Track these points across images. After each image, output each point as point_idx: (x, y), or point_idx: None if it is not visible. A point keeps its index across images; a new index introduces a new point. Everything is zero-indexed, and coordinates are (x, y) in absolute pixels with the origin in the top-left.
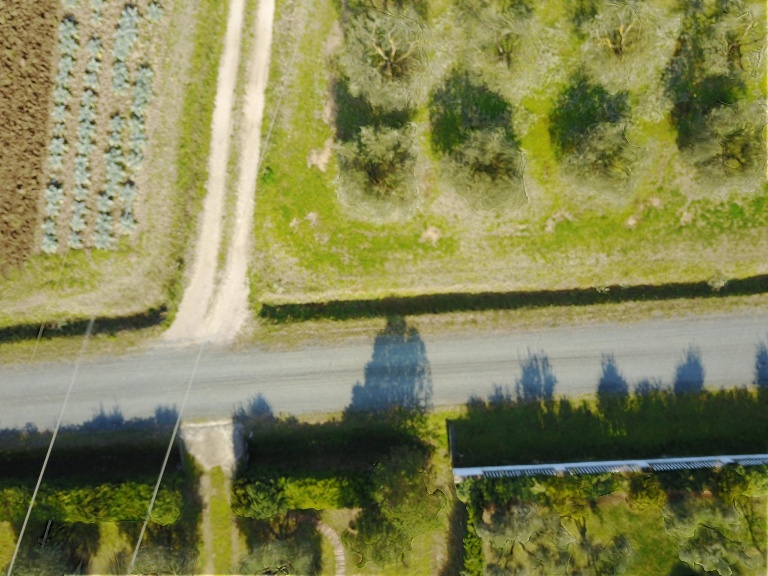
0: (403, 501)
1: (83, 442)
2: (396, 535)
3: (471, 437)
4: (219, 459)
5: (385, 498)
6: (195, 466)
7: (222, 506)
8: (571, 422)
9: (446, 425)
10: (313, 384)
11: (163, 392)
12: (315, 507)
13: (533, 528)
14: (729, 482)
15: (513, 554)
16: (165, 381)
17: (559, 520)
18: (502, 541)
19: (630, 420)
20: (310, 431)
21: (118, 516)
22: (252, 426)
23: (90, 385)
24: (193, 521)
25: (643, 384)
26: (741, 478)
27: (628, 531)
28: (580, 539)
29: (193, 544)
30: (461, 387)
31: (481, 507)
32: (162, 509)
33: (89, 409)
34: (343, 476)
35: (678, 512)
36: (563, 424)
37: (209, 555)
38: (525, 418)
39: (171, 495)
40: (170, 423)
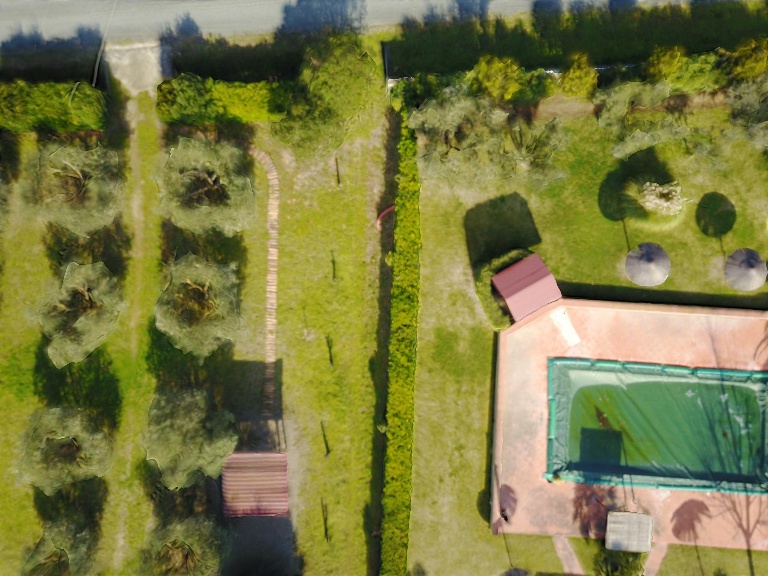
0: (331, 61)
1: (2, 64)
2: (325, 105)
3: (407, 59)
4: (147, 84)
5: (314, 72)
6: (122, 91)
7: (151, 131)
8: (507, 42)
9: (382, 51)
10: (244, 4)
11: (86, 13)
12: (245, 111)
13: (466, 110)
14: (660, 56)
15: (448, 155)
16: (88, 1)
17: (492, 103)
18: (434, 114)
19: (566, 39)
20: (242, 55)
21: (37, 116)
22: (181, 48)
23: (8, 4)
24: (120, 147)
25: (579, 1)
26: (671, 49)
27: (564, 145)
28: (517, 154)
29: (120, 169)
30: (396, 7)
31: (415, 109)
32: (83, 102)
33: (7, 28)
34: (273, 76)
35: (610, 92)
36: (499, 44)
37: (138, 181)
38: (461, 39)
39: (93, 89)
40: (94, 45)
